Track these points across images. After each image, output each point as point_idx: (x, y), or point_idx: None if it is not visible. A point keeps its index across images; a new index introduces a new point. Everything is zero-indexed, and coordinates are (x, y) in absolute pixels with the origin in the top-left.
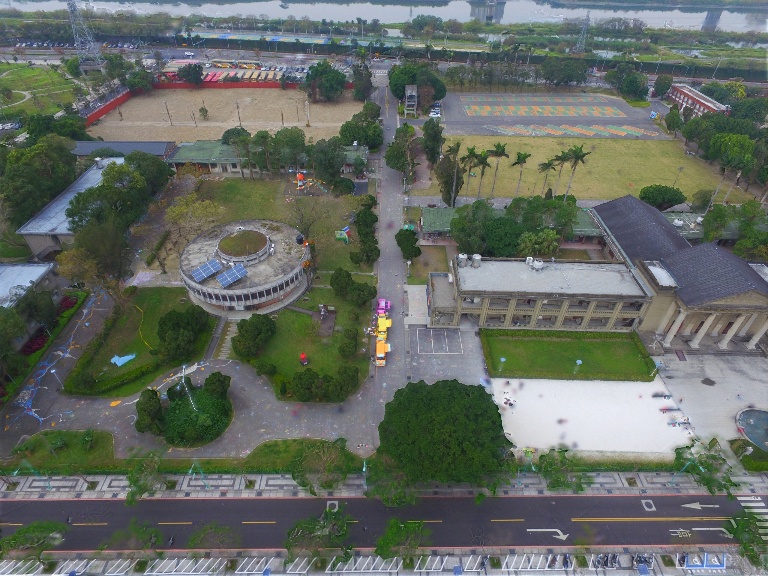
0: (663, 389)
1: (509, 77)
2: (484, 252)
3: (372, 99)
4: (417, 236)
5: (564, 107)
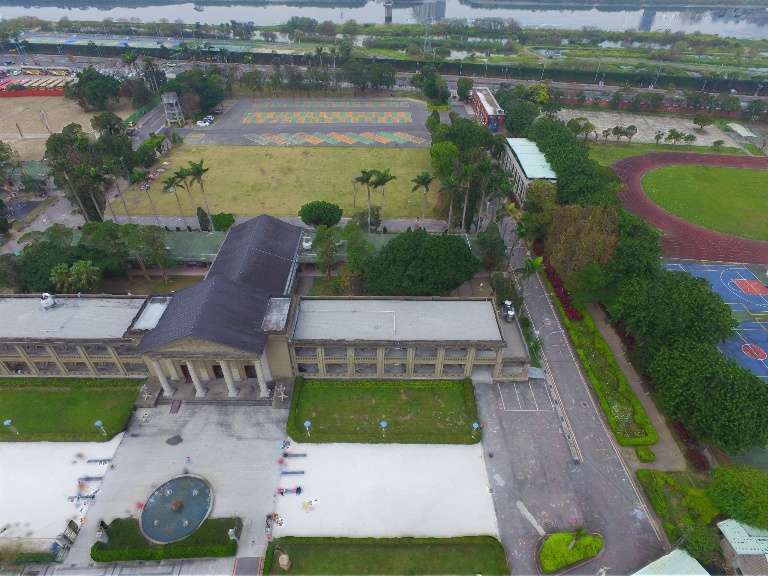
0: (112, 451)
1: (309, 82)
2: (25, 286)
3: (156, 107)
4: None
5: (354, 113)
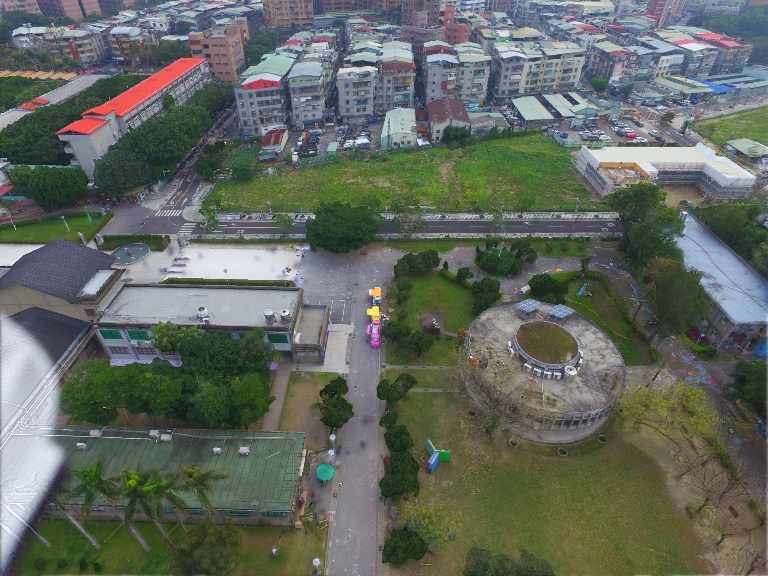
0: None
1: None
2: None
3: None
4: (313, 472)
5: None
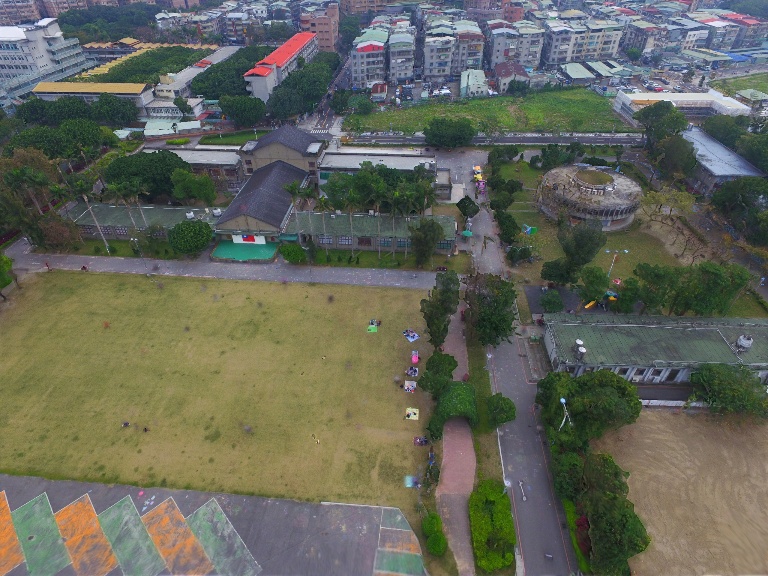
0: None
1: None
2: None
3: None
4: (458, 238)
5: None
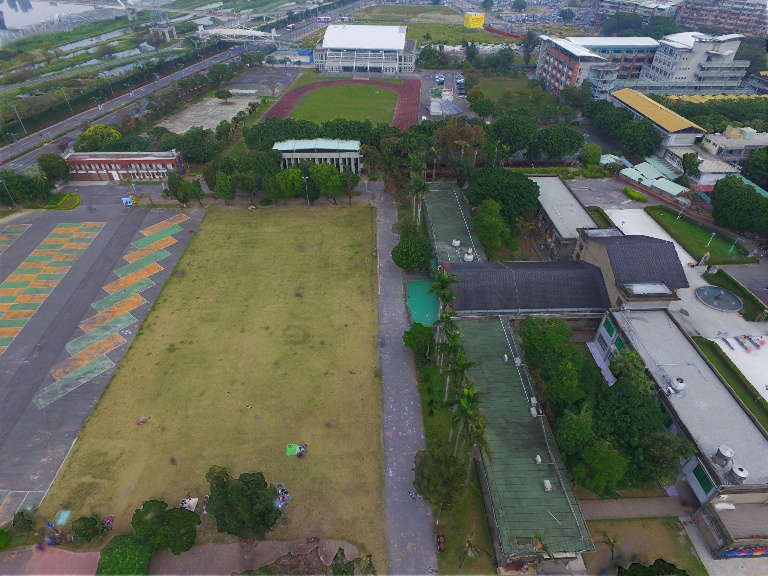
0: (717, 341)
1: None
2: None
3: None
4: None
5: (18, 272)
